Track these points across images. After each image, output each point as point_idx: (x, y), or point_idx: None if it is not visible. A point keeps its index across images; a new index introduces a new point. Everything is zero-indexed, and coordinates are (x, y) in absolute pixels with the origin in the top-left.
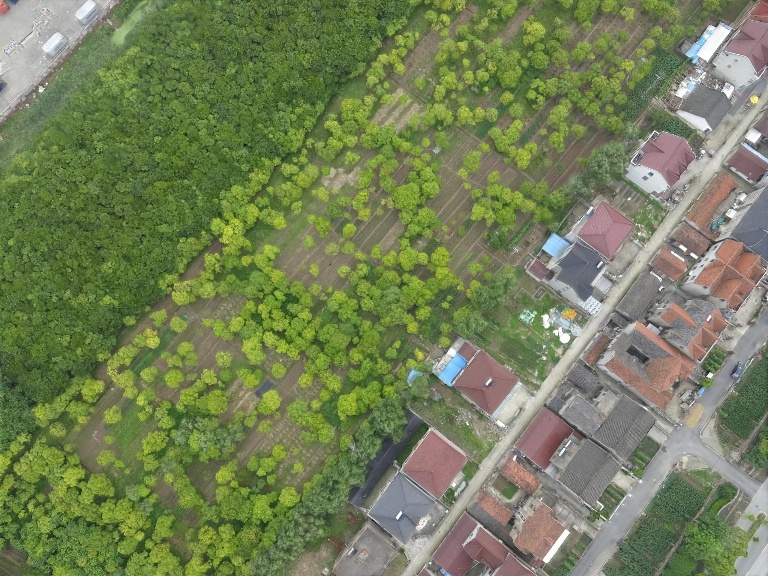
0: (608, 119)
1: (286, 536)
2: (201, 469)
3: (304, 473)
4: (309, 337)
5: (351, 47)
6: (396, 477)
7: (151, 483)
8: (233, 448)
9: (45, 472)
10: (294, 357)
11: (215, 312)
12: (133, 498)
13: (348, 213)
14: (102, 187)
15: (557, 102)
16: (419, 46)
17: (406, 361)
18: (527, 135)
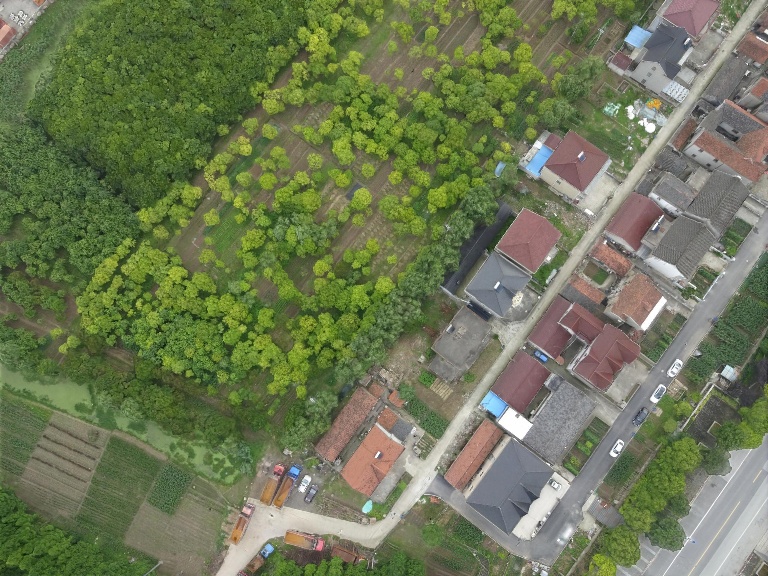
0: None
1: (386, 314)
2: (297, 268)
3: (396, 268)
4: (397, 133)
5: None
6: (491, 254)
7: (251, 278)
8: (328, 243)
9: (151, 271)
10: (383, 155)
11: (303, 122)
12: (236, 290)
13: (429, 17)
14: (192, 3)
15: None
16: None
17: (493, 153)
18: None
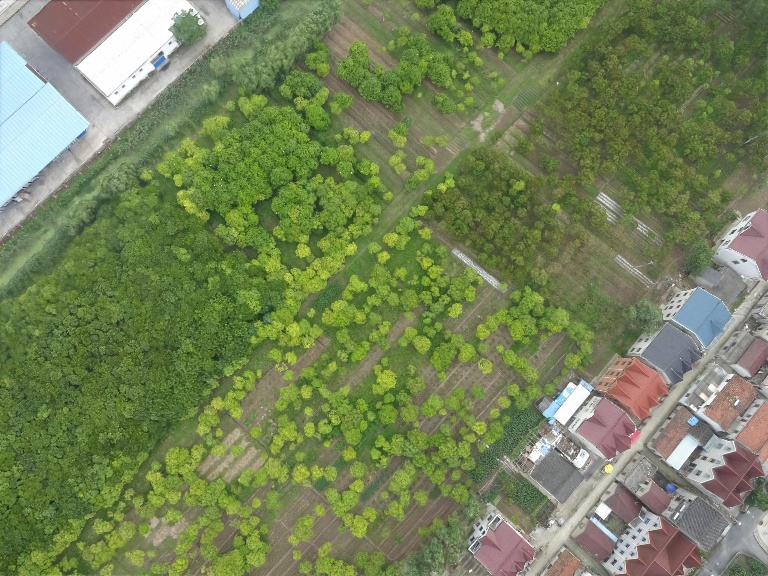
0: (452, 491)
1: None
2: None
3: None
4: None
5: (180, 394)
6: None
7: None
8: None
9: None
10: None
11: None
12: None
13: None
14: None
15: (403, 460)
16: (263, 380)
17: None
18: (369, 492)
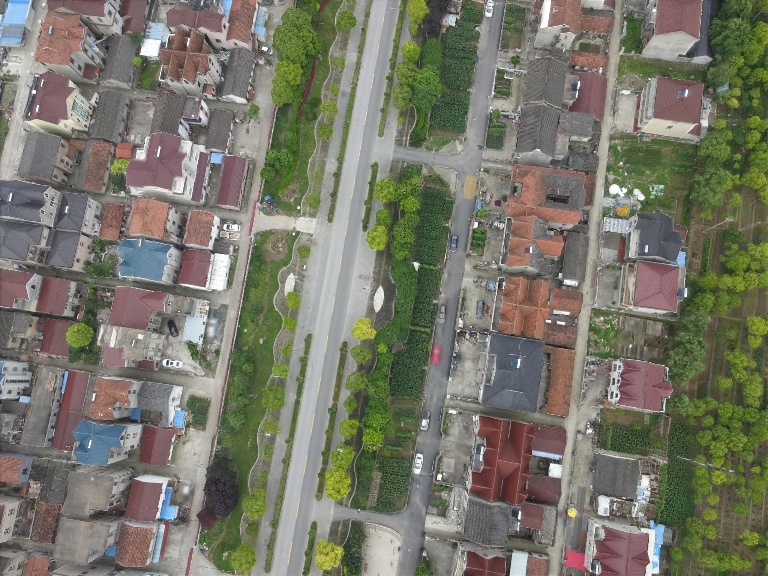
0: (706, 406)
1: None
2: None
3: None
4: None
5: None
6: None
7: None
8: None
9: None
10: None
11: None
12: None
13: None
14: None
15: None
16: None
17: None
18: (760, 357)
